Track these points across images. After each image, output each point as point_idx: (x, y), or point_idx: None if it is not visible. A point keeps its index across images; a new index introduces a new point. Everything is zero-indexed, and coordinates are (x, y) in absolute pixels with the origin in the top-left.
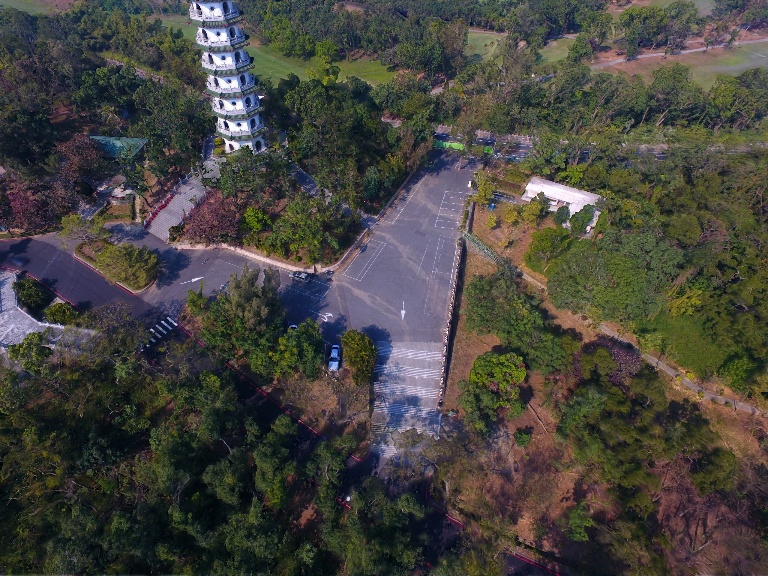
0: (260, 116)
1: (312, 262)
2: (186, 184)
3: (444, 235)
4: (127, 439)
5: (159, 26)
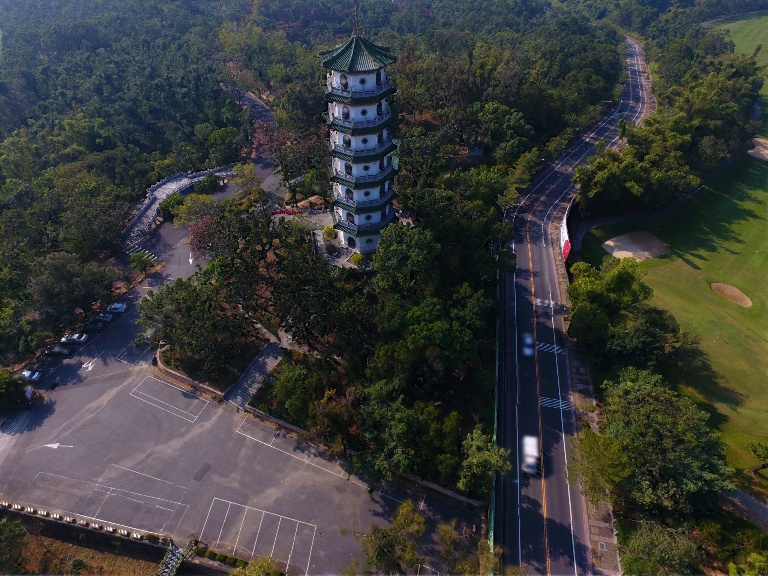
0: (381, 222)
1: (169, 339)
2: (309, 214)
3: (188, 512)
4: None
5: (728, 114)
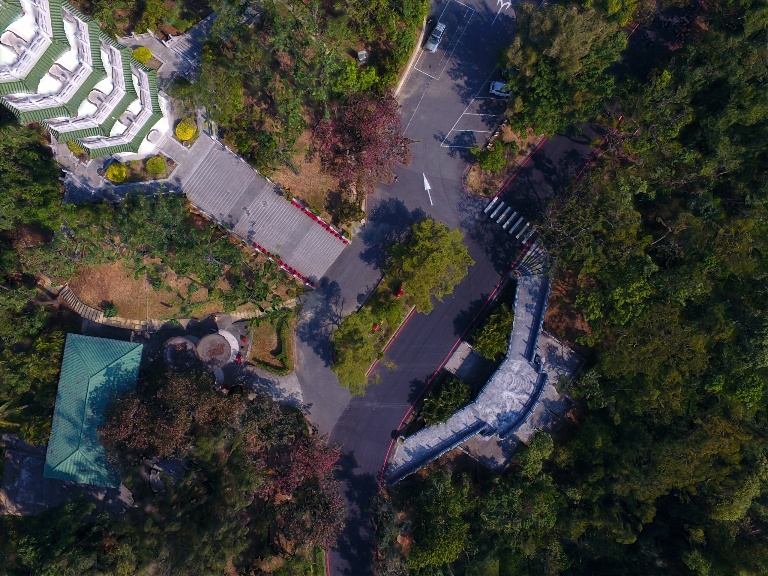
0: None
1: None
2: (233, 223)
3: None
4: (666, 197)
5: None
